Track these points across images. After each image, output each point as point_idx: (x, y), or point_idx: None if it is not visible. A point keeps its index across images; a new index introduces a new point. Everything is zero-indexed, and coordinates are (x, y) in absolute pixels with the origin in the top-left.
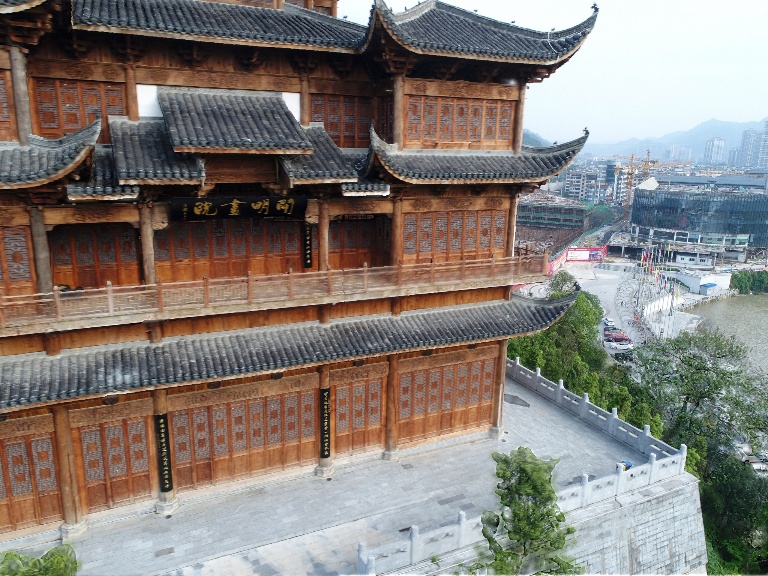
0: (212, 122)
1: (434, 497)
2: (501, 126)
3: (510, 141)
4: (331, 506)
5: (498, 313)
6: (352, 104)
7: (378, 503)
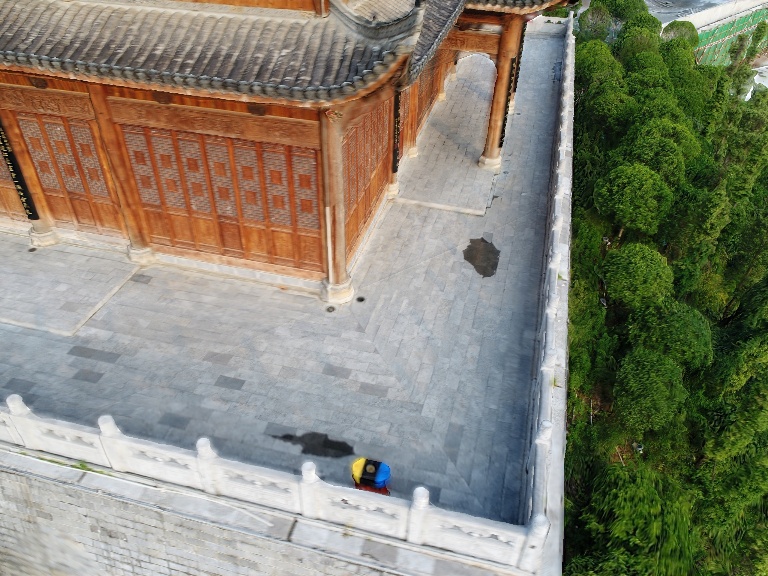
0: None
1: (83, 337)
2: None
3: None
4: None
5: (271, 40)
6: None
7: (6, 307)
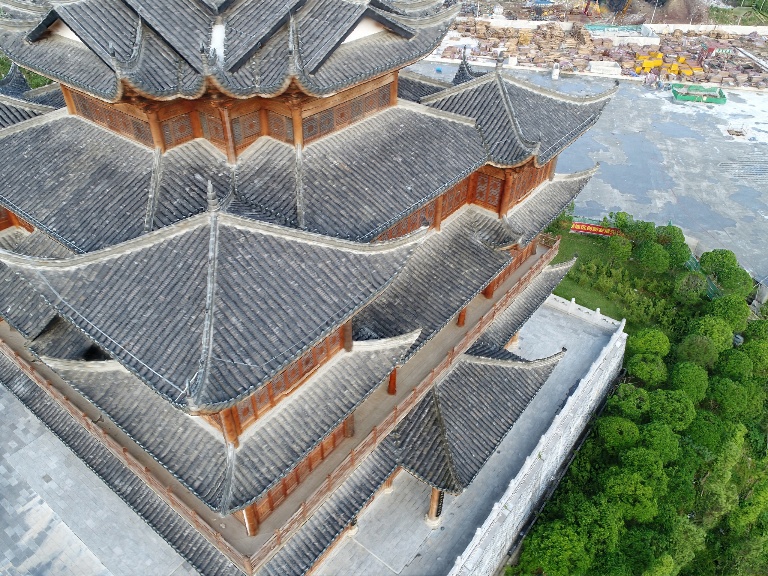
0: None
1: None
2: None
3: None
4: (111, 540)
5: None
6: None
7: (121, 569)
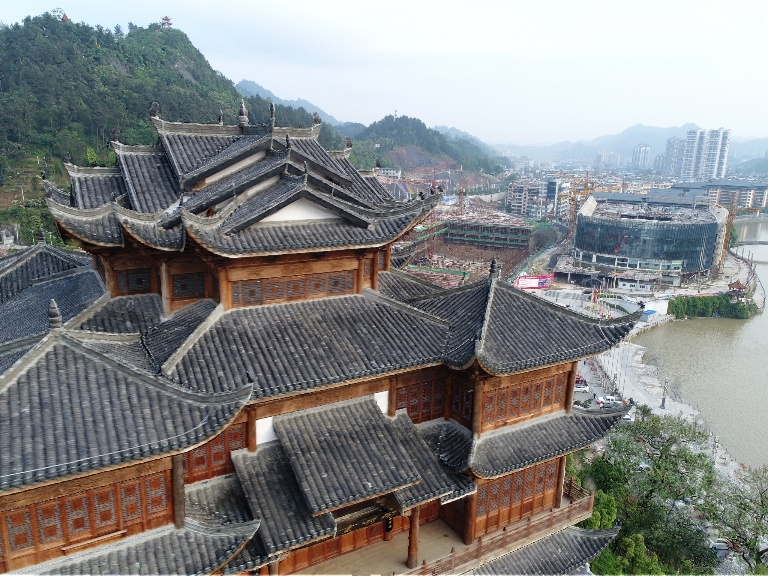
0: (332, 462)
1: None
2: (556, 393)
3: (563, 403)
4: None
5: (551, 548)
6: (430, 386)
7: None
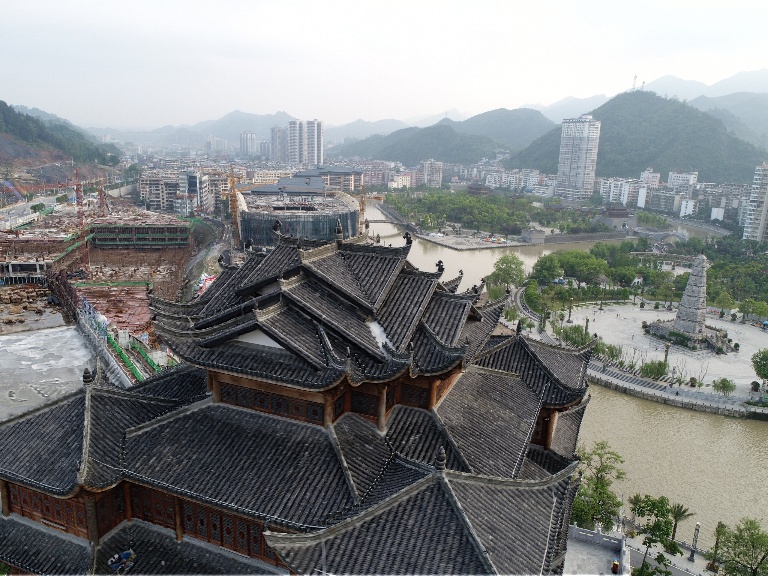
0: None
1: None
2: None
3: None
4: None
5: None
6: None
7: None
